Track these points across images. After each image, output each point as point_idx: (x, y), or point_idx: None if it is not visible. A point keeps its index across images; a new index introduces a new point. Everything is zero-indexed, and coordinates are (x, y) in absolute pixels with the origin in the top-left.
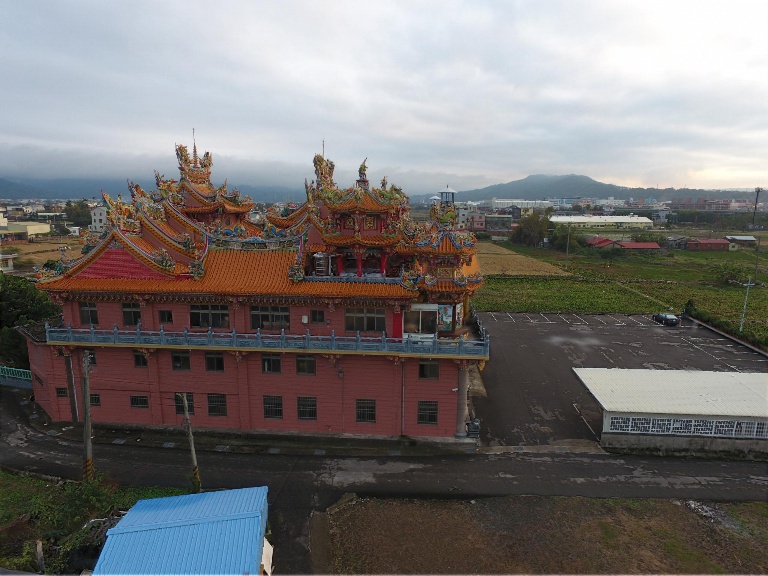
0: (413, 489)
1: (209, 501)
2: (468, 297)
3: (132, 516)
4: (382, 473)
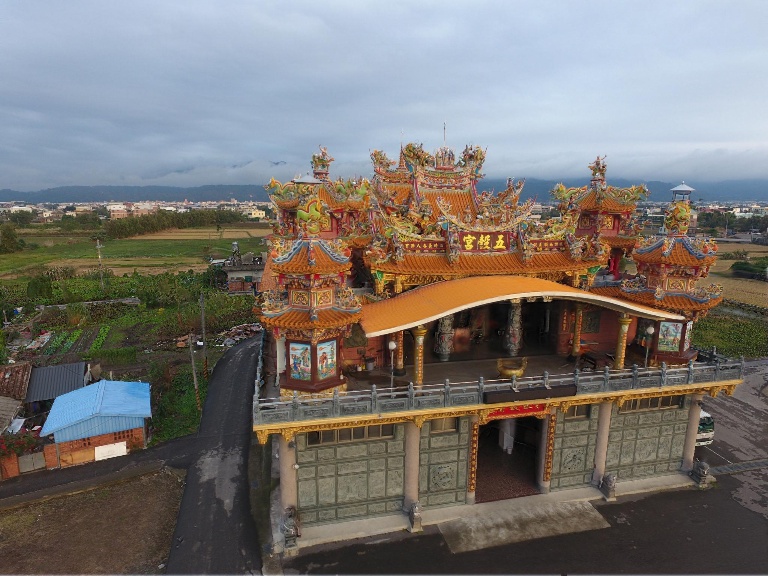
0: (183, 508)
1: (131, 399)
2: (417, 358)
3: (121, 383)
4: (215, 483)
